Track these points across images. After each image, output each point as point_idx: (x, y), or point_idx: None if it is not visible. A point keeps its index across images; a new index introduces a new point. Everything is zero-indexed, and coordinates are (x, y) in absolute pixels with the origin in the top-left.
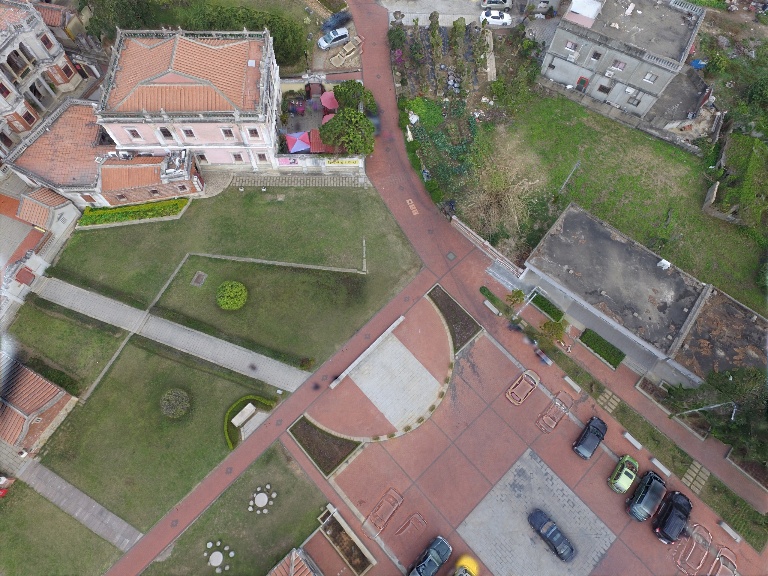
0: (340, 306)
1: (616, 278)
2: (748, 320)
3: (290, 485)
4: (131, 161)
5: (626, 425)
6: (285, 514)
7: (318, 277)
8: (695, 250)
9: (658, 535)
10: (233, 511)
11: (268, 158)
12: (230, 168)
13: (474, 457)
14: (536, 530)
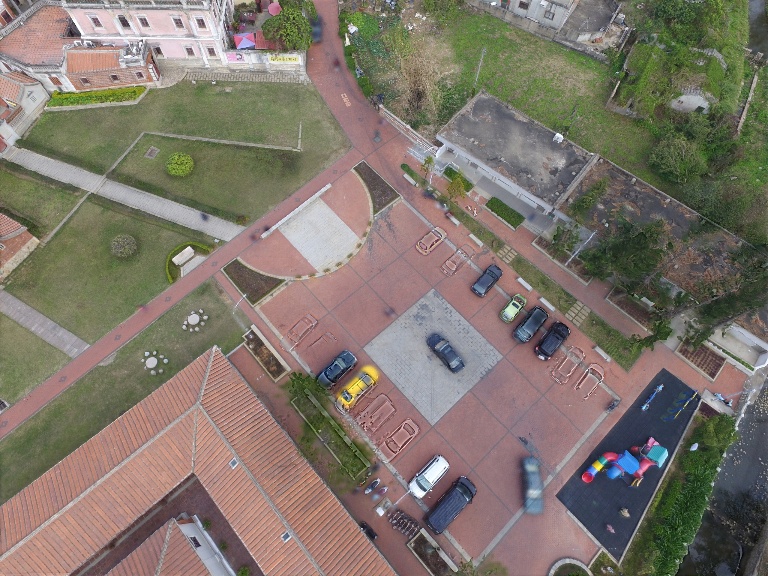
0: (275, 176)
1: (515, 149)
2: (628, 182)
3: (221, 311)
4: (94, 49)
5: (520, 273)
6: (215, 333)
7: (258, 153)
8: (596, 138)
9: (538, 353)
10: (169, 330)
11: (217, 53)
12: (184, 64)
13: (384, 294)
14: (433, 350)
